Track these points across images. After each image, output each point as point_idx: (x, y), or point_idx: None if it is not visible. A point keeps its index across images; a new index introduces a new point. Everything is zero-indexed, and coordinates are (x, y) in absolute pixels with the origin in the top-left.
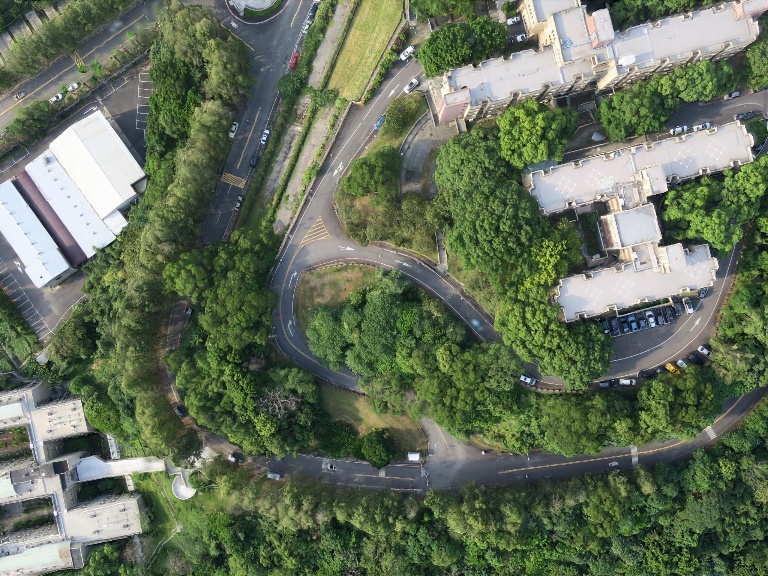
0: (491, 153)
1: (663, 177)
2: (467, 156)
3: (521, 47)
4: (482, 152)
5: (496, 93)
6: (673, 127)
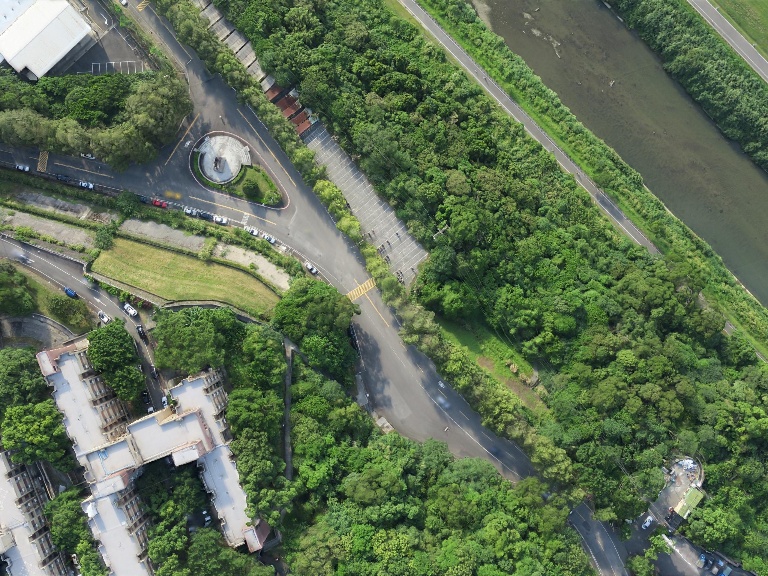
0: (8, 399)
1: None
2: None
3: (138, 412)
4: (4, 391)
5: (63, 397)
6: None
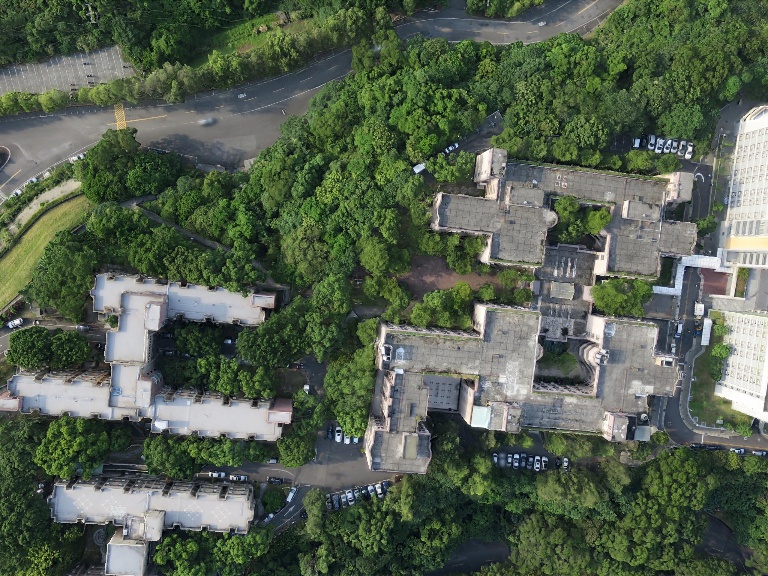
0: (26, 456)
1: (158, 528)
2: (2, 453)
3: None
4: (15, 455)
5: (49, 407)
6: (213, 470)
